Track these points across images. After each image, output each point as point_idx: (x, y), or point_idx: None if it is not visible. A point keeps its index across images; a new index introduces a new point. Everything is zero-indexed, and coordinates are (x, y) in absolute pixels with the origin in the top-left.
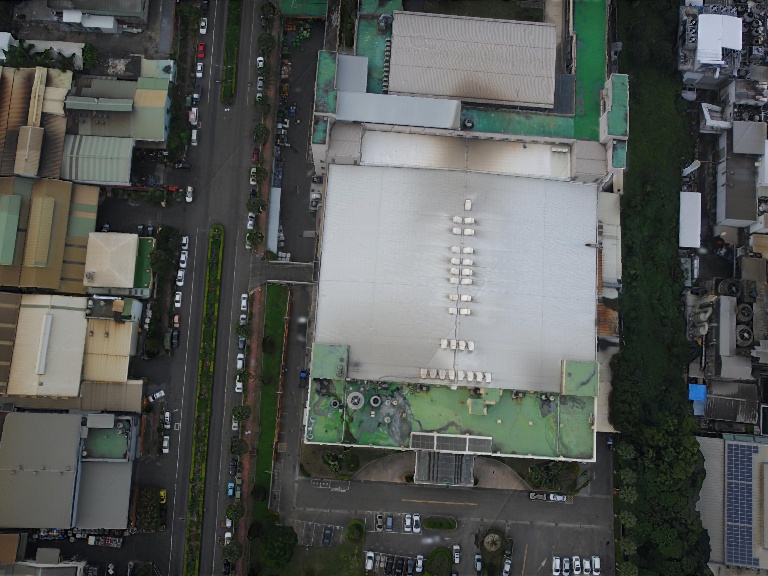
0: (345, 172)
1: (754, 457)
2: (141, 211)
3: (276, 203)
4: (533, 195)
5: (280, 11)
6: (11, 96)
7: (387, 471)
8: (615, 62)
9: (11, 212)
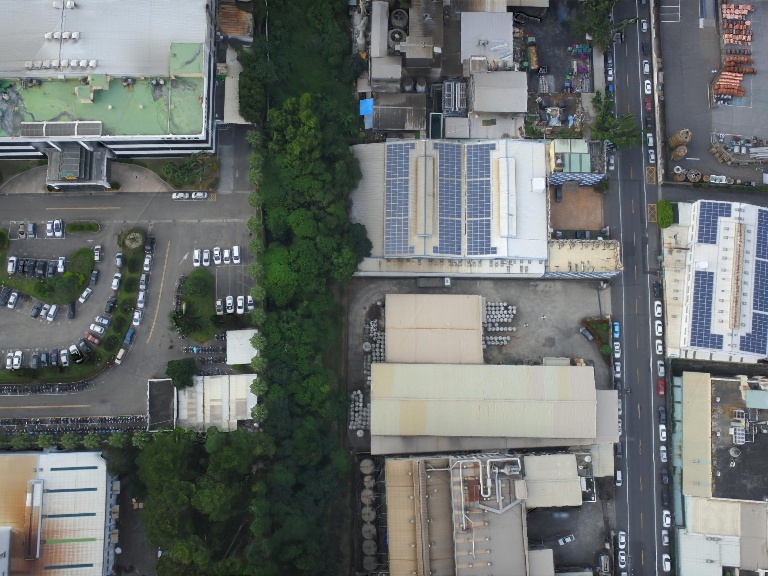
0: None
1: (411, 153)
2: None
3: None
4: None
5: None
6: None
7: (31, 183)
8: None
9: None
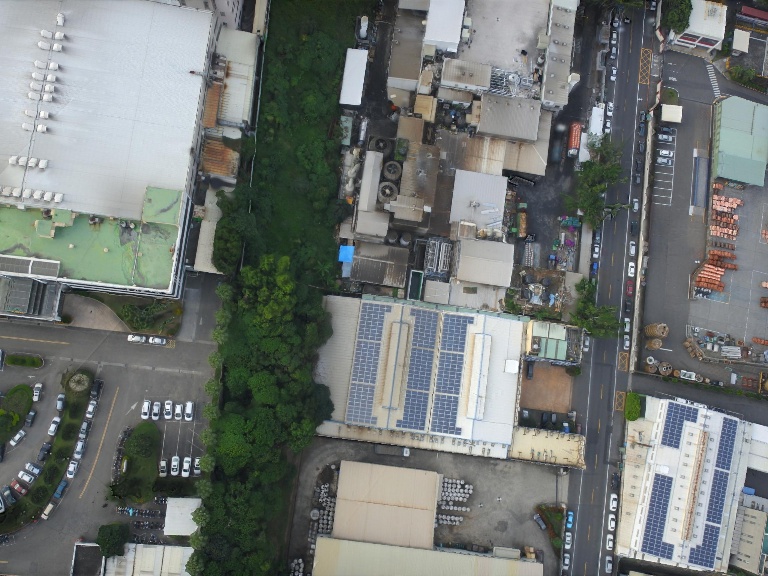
0: None
1: (386, 316)
2: None
3: None
4: (138, 17)
5: None
6: None
7: None
8: None
9: None
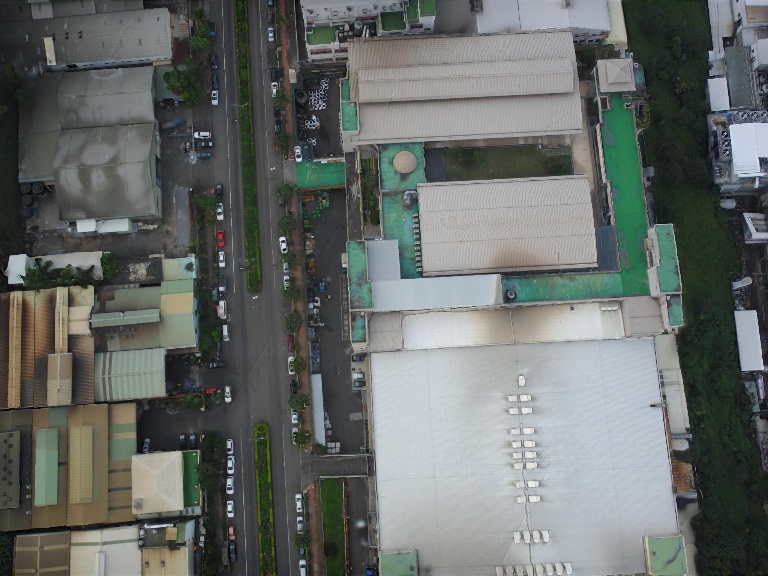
0: (388, 360)
1: None
2: (181, 419)
3: (318, 391)
4: (588, 359)
5: (296, 185)
6: (34, 321)
7: None
8: (649, 189)
9: (50, 448)
